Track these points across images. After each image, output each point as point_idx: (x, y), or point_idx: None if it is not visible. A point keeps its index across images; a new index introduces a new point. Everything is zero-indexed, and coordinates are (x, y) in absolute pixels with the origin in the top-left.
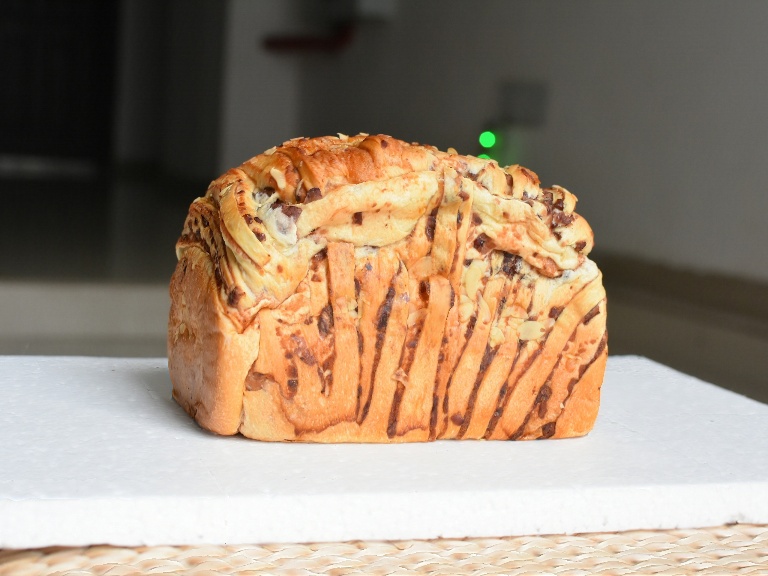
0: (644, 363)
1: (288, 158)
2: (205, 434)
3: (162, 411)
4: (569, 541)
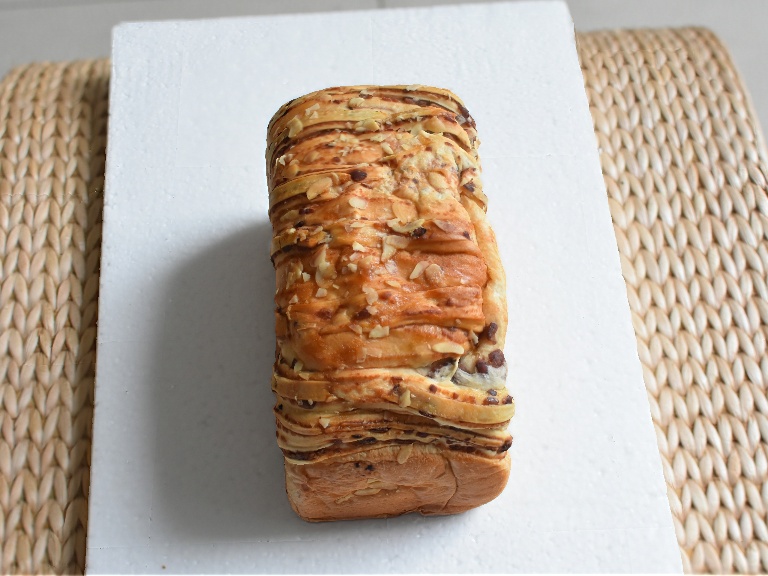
0: (147, 32)
1: (426, 326)
2: (465, 514)
3: (368, 540)
4: (629, 300)
